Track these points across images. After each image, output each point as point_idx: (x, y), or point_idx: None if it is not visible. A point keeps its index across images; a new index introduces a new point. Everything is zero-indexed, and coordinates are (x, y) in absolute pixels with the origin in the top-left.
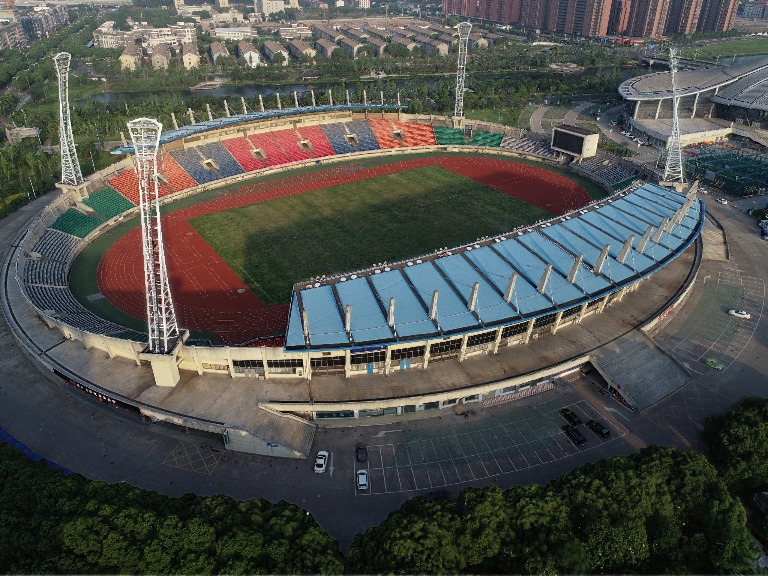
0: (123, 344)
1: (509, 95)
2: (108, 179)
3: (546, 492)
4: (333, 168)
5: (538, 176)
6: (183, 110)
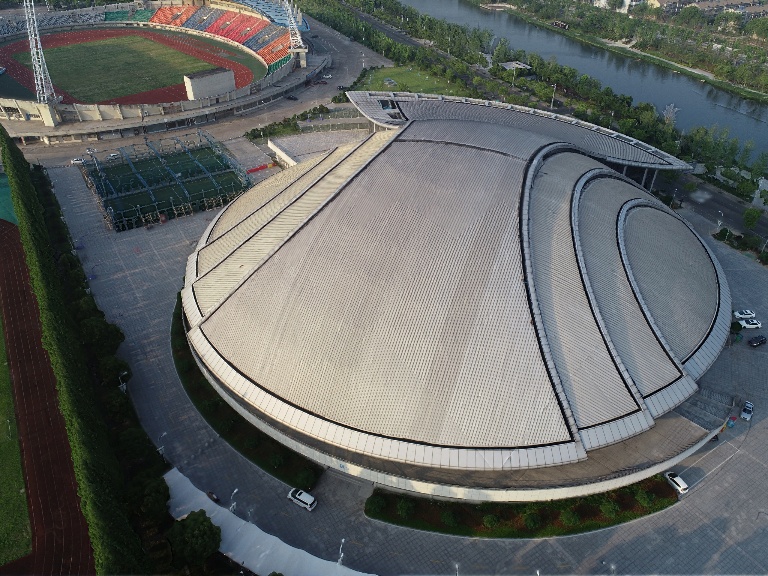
0: None
1: (488, 81)
2: None
3: None
4: (225, 50)
5: None
6: (359, 5)
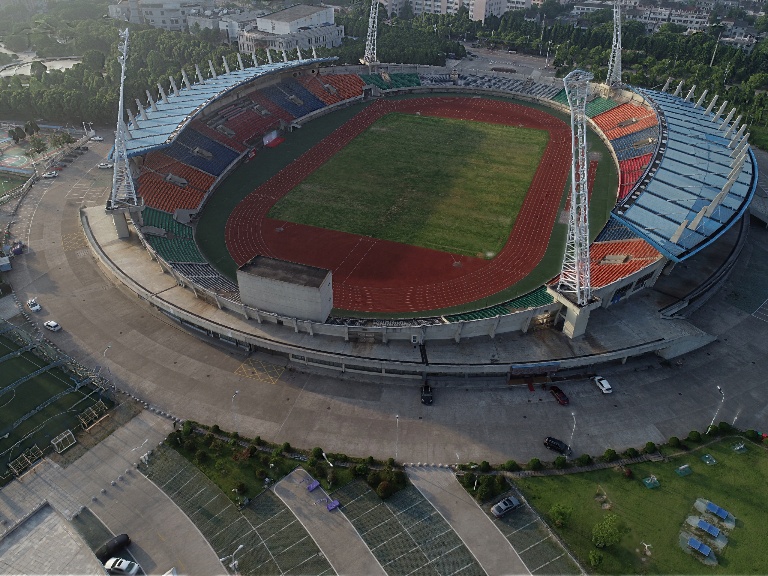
0: (392, 66)
1: None
2: (633, 103)
3: (211, 73)
4: None
5: None
6: None
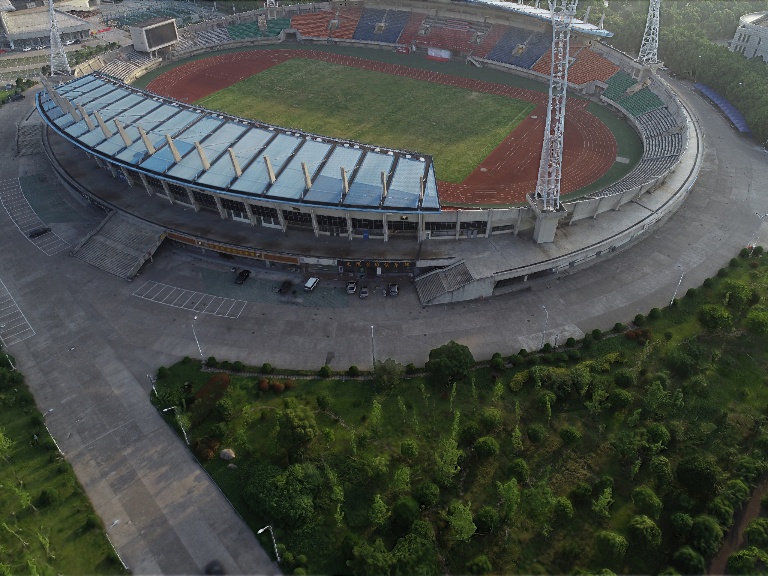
0: None
1: None
2: None
3: None
4: None
5: (199, 68)
6: None
